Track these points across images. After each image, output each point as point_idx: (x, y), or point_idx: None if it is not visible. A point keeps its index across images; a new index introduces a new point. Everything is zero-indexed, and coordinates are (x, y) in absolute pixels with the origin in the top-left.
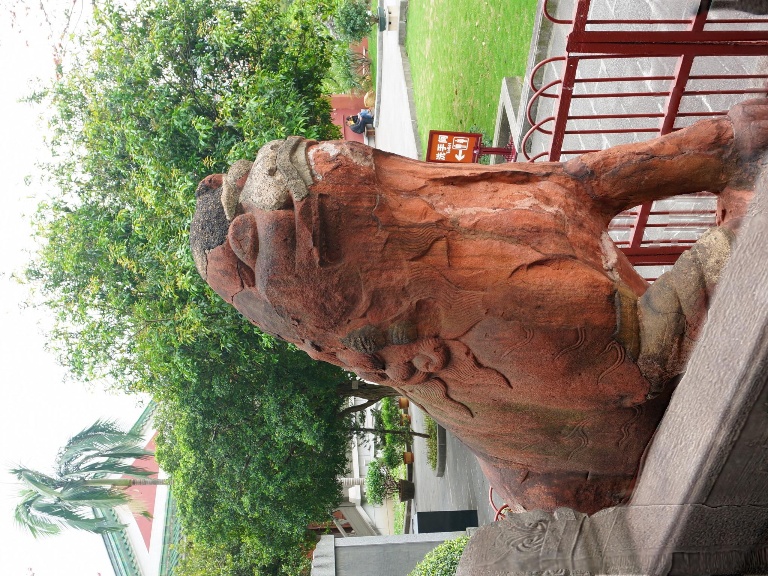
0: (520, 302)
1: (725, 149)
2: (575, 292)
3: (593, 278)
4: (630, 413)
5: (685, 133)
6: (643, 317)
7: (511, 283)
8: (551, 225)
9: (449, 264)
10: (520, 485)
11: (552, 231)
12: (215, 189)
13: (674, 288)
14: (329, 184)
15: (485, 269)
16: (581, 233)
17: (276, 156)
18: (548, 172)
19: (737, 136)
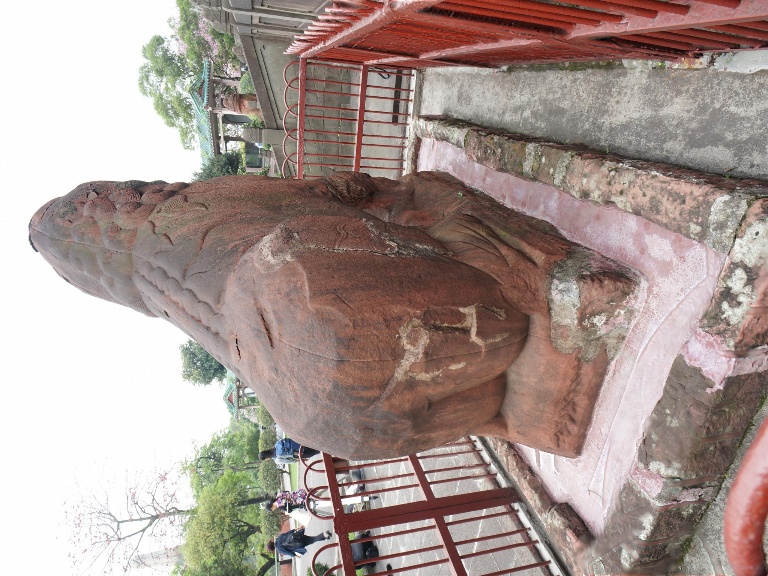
0: None
1: None
2: None
3: None
4: None
5: None
6: None
7: None
8: None
9: None
10: None
11: None
12: None
13: None
14: None
15: None
16: None
17: None
18: None
19: None
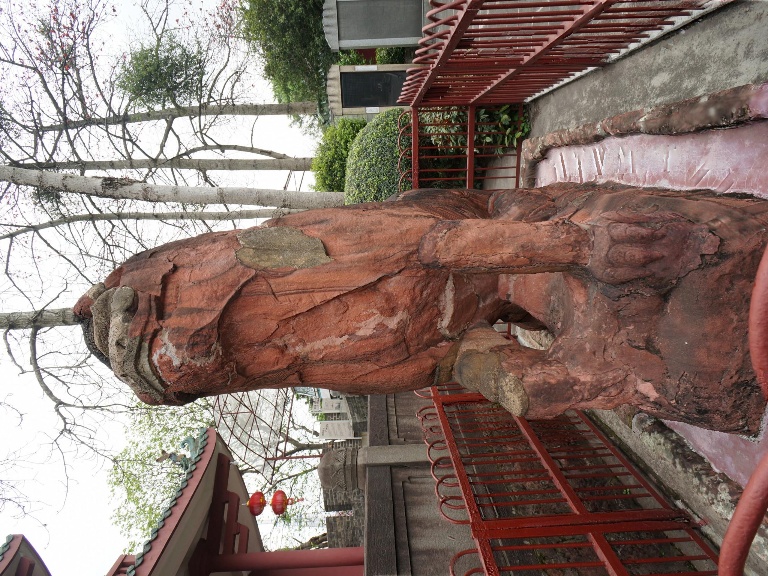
0: (360, 389)
1: (575, 265)
2: (403, 382)
3: (420, 369)
4: None
5: (542, 249)
6: (455, 375)
7: (353, 383)
8: (390, 343)
9: (302, 381)
10: None
11: (390, 347)
12: (88, 321)
13: (477, 389)
14: (180, 386)
15: (332, 379)
16: (421, 318)
17: (123, 362)
18: (401, 269)
19: (589, 268)
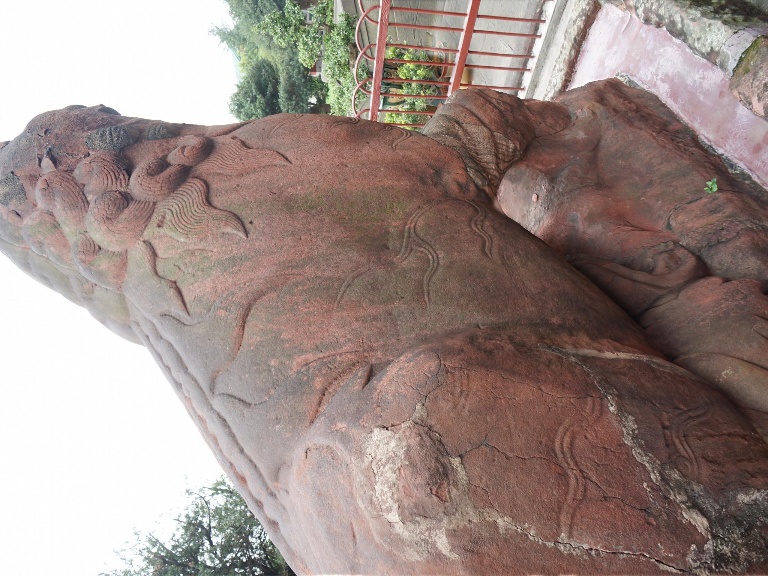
0: None
1: None
2: None
3: None
4: (468, 207)
5: None
6: None
7: None
8: None
9: None
10: (361, 392)
11: None
12: None
13: None
14: None
15: None
16: None
17: None
18: None
19: None
